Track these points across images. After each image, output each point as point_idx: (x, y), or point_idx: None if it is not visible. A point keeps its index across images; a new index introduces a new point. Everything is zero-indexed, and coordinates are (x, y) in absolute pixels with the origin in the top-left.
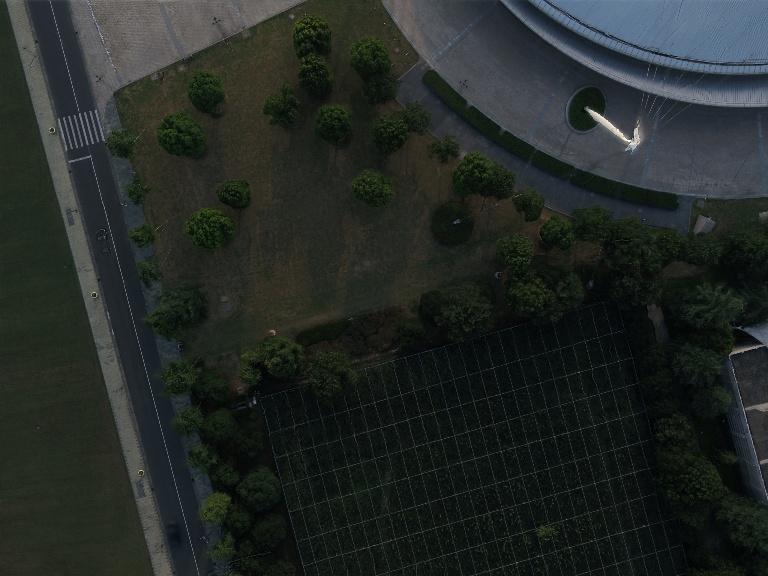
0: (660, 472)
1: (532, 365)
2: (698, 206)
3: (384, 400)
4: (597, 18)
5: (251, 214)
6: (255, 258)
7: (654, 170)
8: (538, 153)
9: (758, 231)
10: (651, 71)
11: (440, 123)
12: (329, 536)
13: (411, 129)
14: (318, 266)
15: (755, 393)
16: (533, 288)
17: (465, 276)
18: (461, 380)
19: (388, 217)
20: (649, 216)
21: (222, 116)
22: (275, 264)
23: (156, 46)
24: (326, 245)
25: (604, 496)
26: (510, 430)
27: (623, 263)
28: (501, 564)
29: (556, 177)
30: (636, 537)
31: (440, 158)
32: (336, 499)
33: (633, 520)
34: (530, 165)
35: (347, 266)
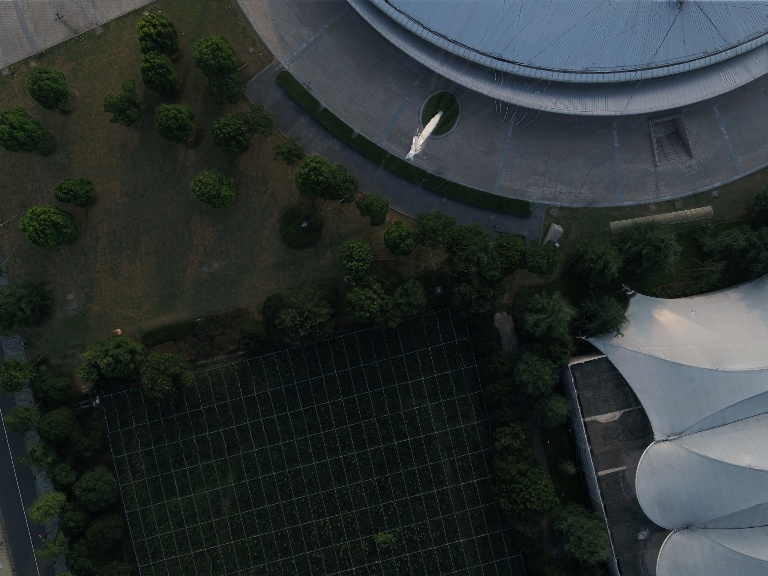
0: (496, 481)
1: (377, 370)
2: (551, 214)
3: (225, 402)
4: (439, 22)
5: (98, 212)
6: (102, 256)
7: (508, 177)
8: (390, 157)
9: (611, 240)
10: (499, 77)
11: (293, 124)
12: (166, 537)
13: (252, 130)
14: (166, 266)
15: (595, 404)
16: (368, 293)
17: (314, 279)
18: (303, 384)
19: (237, 218)
20: (501, 223)
21: (72, 113)
22: (122, 263)
23: (8, 41)
24: (174, 245)
25: (444, 503)
26: (351, 435)
27: (460, 270)
28: (338, 569)
29: (409, 181)
30: (475, 545)
31: (284, 160)
32: (174, 500)
33: (472, 528)
34: (383, 169)
35: (195, 267)
